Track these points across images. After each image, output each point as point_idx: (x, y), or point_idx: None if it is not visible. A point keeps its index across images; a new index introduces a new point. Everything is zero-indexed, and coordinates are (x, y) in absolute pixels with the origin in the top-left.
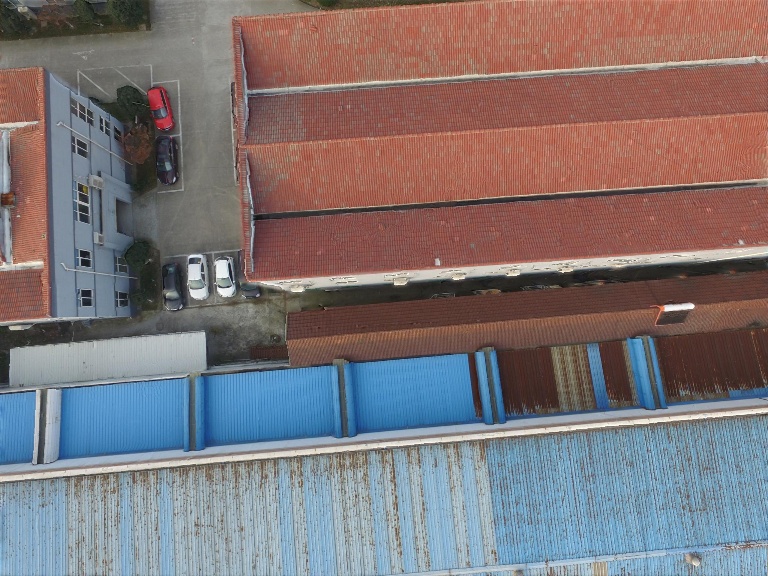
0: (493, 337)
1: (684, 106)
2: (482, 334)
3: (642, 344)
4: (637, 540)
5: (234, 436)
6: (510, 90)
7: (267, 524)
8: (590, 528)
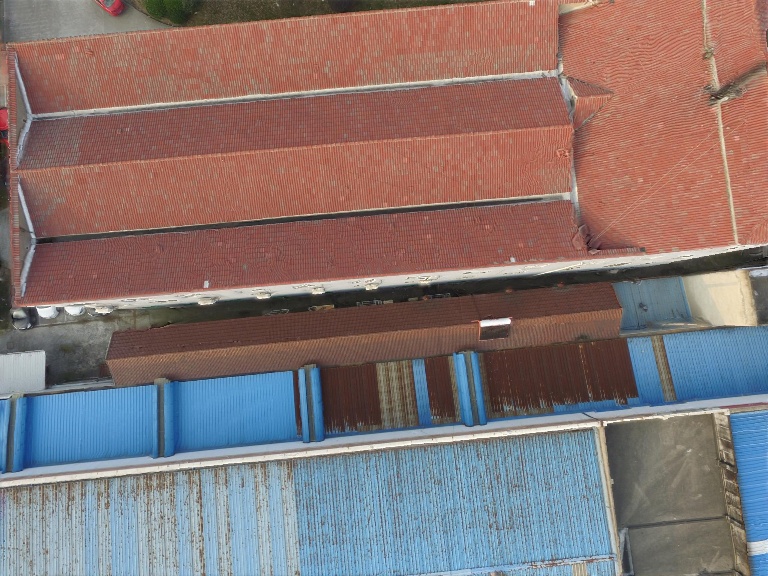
0: (316, 354)
1: (461, 123)
2: (304, 351)
3: (463, 360)
4: (442, 559)
5: (56, 457)
6: (290, 110)
7: (72, 546)
8: (395, 548)
